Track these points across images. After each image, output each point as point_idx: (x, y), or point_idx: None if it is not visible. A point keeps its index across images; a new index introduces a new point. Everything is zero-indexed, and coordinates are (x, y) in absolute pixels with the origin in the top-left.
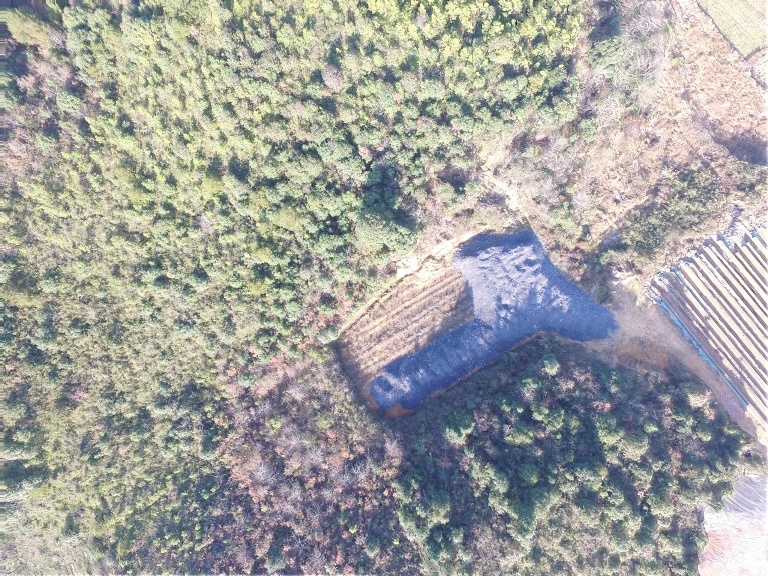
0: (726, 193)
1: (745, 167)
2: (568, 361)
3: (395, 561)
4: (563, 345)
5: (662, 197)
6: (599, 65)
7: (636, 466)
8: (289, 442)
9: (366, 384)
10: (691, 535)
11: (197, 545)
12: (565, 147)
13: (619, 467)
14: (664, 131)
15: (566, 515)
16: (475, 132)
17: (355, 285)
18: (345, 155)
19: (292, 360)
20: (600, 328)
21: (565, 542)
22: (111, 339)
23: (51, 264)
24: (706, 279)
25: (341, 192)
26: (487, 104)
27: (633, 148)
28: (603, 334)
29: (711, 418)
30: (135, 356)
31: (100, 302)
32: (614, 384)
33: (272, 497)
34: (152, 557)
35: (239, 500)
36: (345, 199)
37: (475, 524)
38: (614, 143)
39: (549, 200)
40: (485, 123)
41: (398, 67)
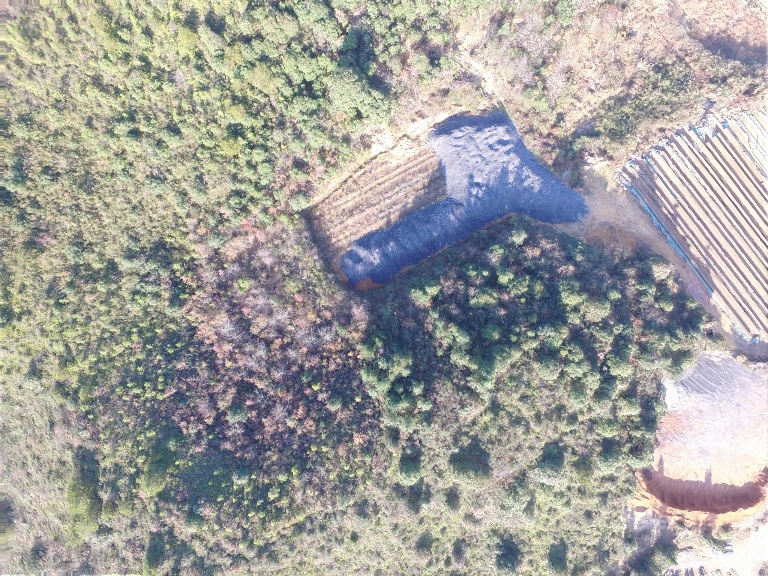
0: (699, 86)
1: (718, 61)
2: (536, 235)
3: (356, 417)
4: (533, 226)
5: (636, 89)
6: None
7: (597, 328)
8: (256, 302)
9: (337, 257)
10: (650, 401)
11: (159, 394)
12: (541, 29)
13: (580, 328)
14: (641, 26)
15: (526, 372)
16: (452, 6)
17: (328, 152)
18: (321, 16)
19: (263, 224)
20: (570, 211)
21: (524, 397)
22: (81, 188)
23: (24, 110)
24: (676, 167)
25: (317, 56)
26: None
27: (609, 36)
28: (573, 217)
29: (674, 291)
30: (105, 208)
31: (72, 153)
32: (579, 253)
33: (237, 354)
34: (114, 405)
35: (204, 357)
36: (320, 63)
37: (436, 379)
38: (591, 32)
39: (524, 80)
40: None
41: None
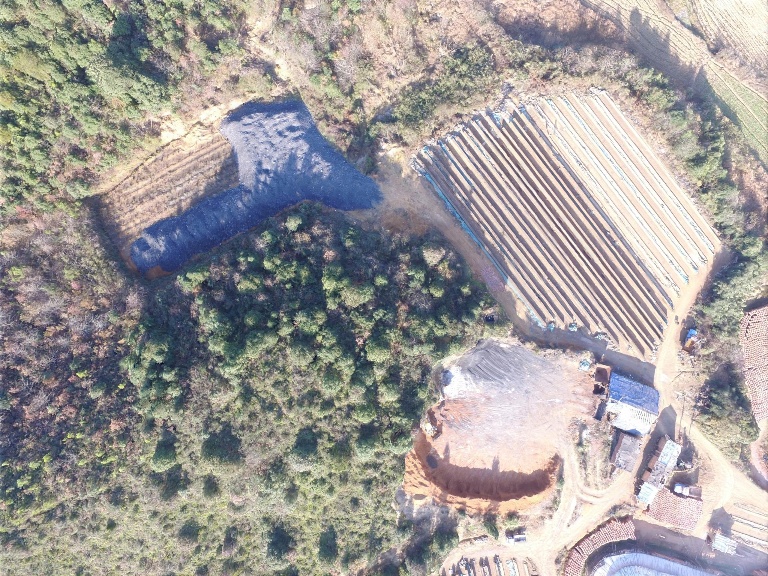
0: (499, 72)
1: (518, 46)
2: (315, 221)
3: (117, 404)
4: (325, 213)
5: (438, 75)
6: None
7: (356, 313)
8: (29, 290)
9: (126, 245)
10: (415, 387)
11: None
12: (329, 14)
13: (339, 314)
14: (445, 11)
15: (281, 358)
16: None
17: (106, 139)
18: (87, 1)
19: (40, 211)
20: (363, 198)
21: (277, 383)
22: None
23: None
24: (471, 153)
25: (89, 42)
26: None
27: (403, 21)
28: (367, 204)
29: (447, 277)
30: None
31: None
32: (349, 238)
33: (5, 342)
34: None
35: None
36: (91, 49)
37: (193, 366)
38: (388, 17)
39: (310, 65)
40: None
41: None
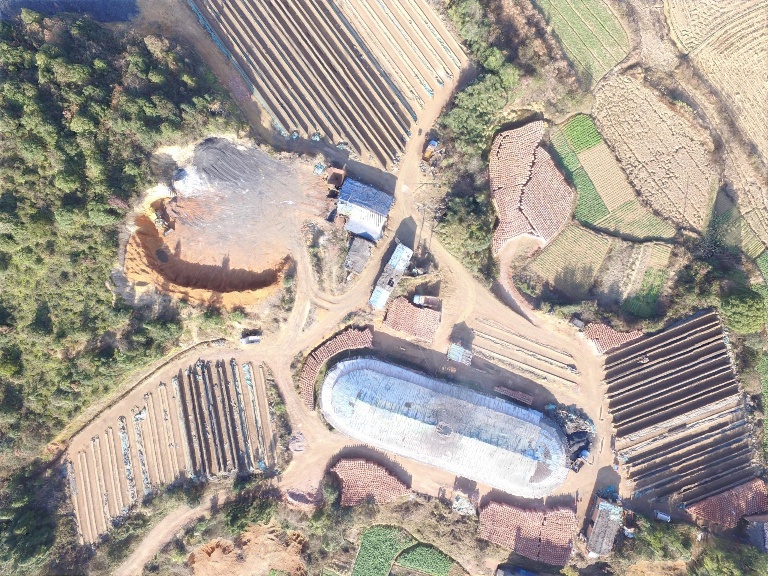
0: None
1: None
2: None
3: None
4: None
5: None
6: None
7: (65, 88)
8: None
9: None
10: (125, 165)
11: None
12: None
13: (50, 89)
14: None
15: None
16: None
17: None
18: None
19: None
20: (118, 10)
21: None
22: None
23: None
24: None
25: None
26: None
27: None
28: (122, 16)
29: (170, 66)
30: None
31: None
32: (75, 27)
33: None
34: None
35: None
36: None
37: None
38: None
39: None
40: None
41: None
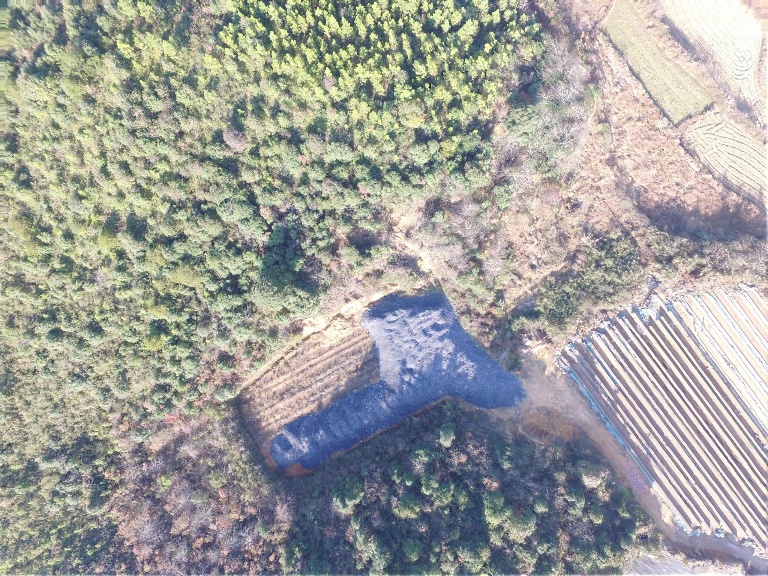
0: (644, 264)
1: (665, 238)
2: (466, 432)
3: None
4: (468, 412)
5: (580, 264)
6: (513, 133)
7: (520, 548)
8: (178, 501)
9: (266, 441)
10: None
11: None
12: (478, 212)
13: (503, 548)
14: (586, 197)
15: None
16: (384, 195)
17: (255, 344)
18: (245, 216)
19: (188, 417)
20: (507, 396)
21: None
22: (1, 390)
23: None
24: (617, 352)
25: (242, 251)
26: (397, 167)
27: (550, 215)
28: (510, 402)
29: (605, 499)
30: (26, 407)
31: None
32: (507, 460)
33: (157, 556)
34: None
35: (124, 557)
36: (246, 259)
37: None
38: (532, 208)
39: (458, 265)
40: (394, 186)
41: (304, 128)
